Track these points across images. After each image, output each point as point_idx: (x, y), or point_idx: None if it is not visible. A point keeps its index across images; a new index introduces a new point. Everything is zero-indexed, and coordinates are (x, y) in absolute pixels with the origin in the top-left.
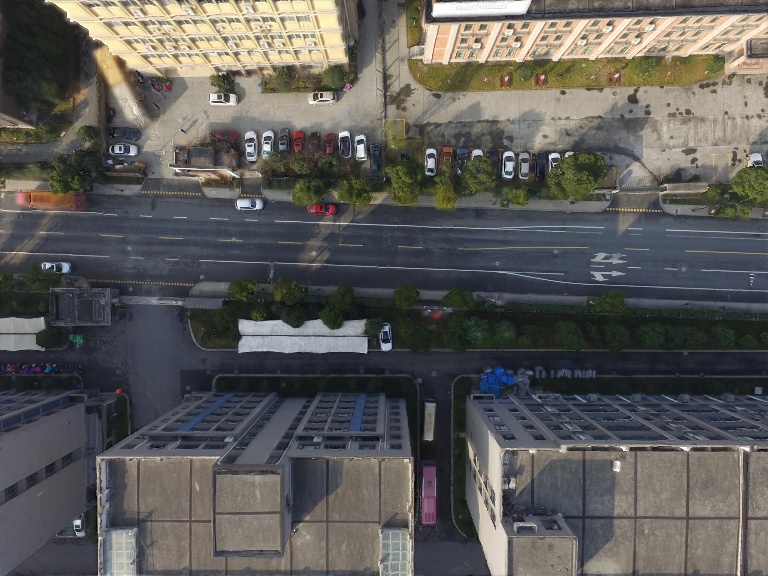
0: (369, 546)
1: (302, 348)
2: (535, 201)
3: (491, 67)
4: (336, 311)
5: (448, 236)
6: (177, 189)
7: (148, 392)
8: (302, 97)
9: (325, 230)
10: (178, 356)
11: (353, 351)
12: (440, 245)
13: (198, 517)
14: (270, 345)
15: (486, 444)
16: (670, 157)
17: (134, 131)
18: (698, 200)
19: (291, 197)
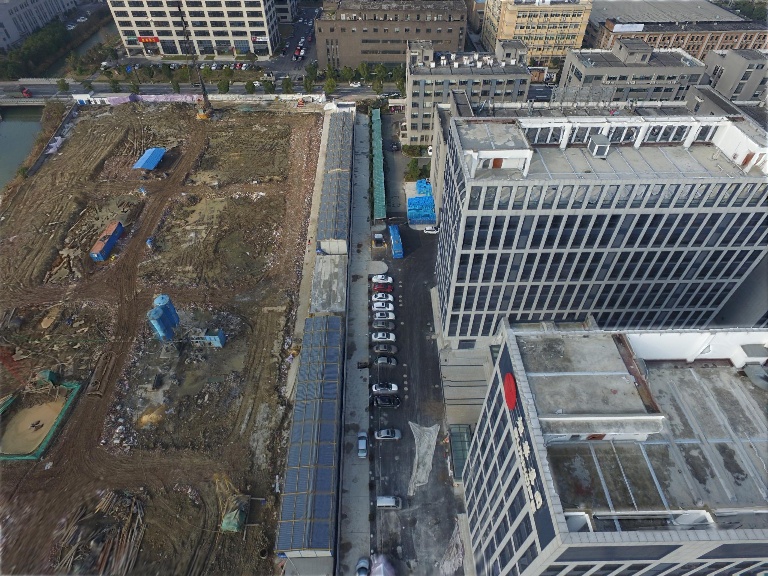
0: (680, 64)
1: None
2: None
3: None
4: None
5: None
6: None
7: None
8: None
9: None
10: None
11: None
12: None
13: None
14: None
15: None
16: None
17: None
18: None
19: None
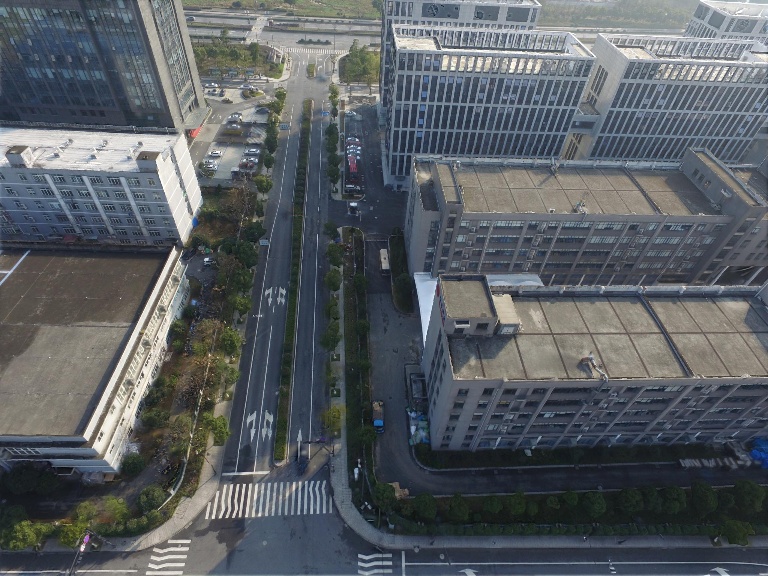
0: None
1: None
2: None
3: None
4: None
5: None
6: None
7: None
8: None
9: None
10: None
11: None
12: None
13: None
14: None
15: None
16: None
17: None
18: None
19: None
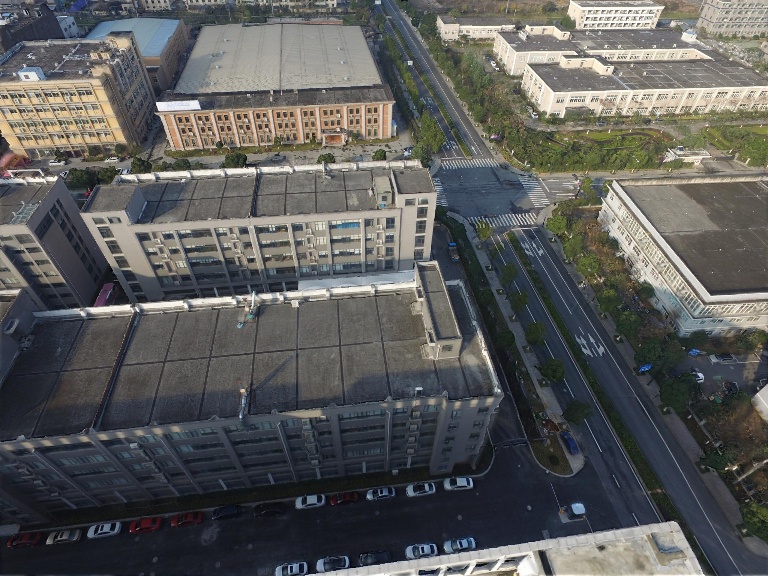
0: (13, 214)
1: None
2: None
3: (206, 150)
4: None
5: None
6: None
7: None
8: (102, 162)
9: None
10: None
11: None
12: None
13: None
14: None
15: None
16: None
17: None
18: None
19: (78, 192)
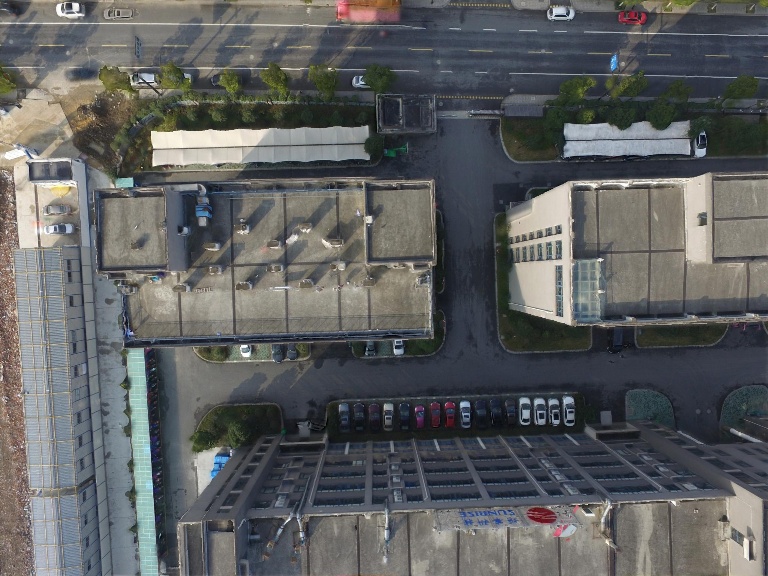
0: None
1: (627, 151)
2: None
3: None
4: (672, 106)
5: (754, 44)
6: (486, 1)
7: (461, 207)
8: None
9: (633, 40)
10: (491, 170)
11: (677, 153)
12: (746, 53)
13: (658, 247)
14: (595, 149)
15: None
16: None
17: None
18: None
19: (600, 7)
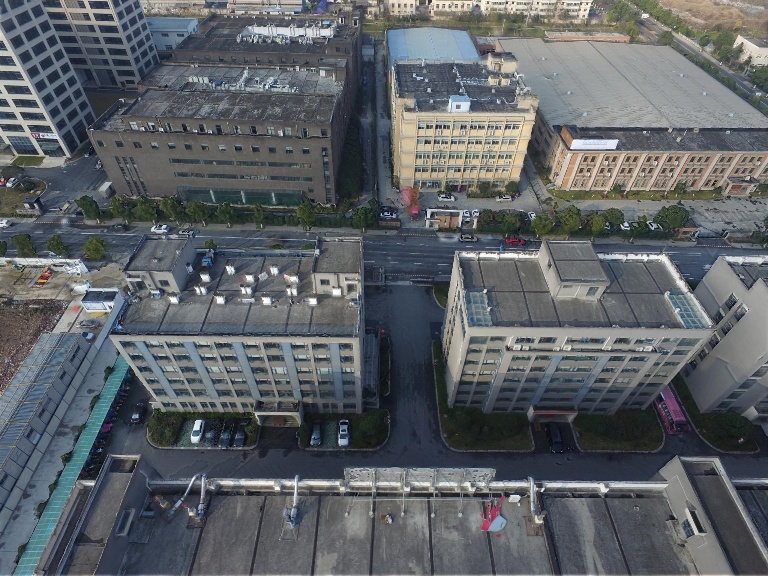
0: (662, 307)
1: None
2: (649, 241)
3: (593, 192)
4: None
5: None
6: (420, 233)
7: (405, 335)
8: (491, 200)
9: None
10: (427, 313)
11: None
12: None
13: (529, 289)
14: None
15: (705, 290)
16: (719, 225)
17: (395, 208)
18: (751, 241)
19: (494, 237)
